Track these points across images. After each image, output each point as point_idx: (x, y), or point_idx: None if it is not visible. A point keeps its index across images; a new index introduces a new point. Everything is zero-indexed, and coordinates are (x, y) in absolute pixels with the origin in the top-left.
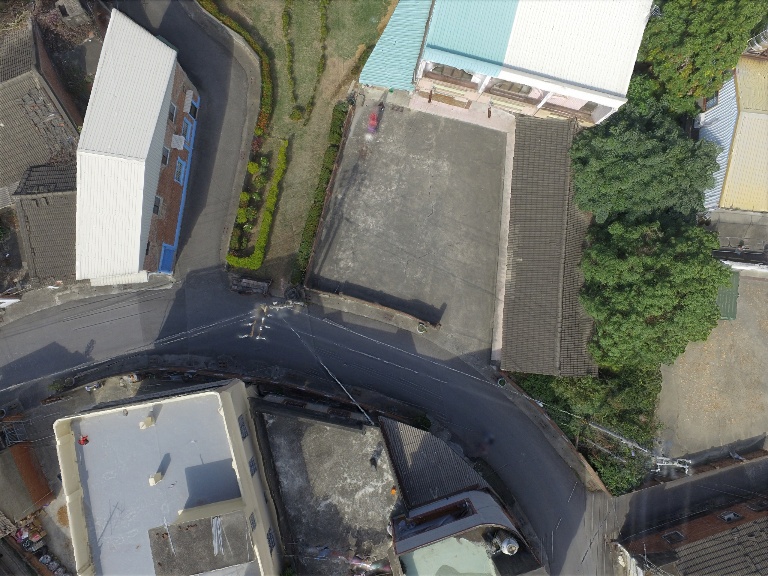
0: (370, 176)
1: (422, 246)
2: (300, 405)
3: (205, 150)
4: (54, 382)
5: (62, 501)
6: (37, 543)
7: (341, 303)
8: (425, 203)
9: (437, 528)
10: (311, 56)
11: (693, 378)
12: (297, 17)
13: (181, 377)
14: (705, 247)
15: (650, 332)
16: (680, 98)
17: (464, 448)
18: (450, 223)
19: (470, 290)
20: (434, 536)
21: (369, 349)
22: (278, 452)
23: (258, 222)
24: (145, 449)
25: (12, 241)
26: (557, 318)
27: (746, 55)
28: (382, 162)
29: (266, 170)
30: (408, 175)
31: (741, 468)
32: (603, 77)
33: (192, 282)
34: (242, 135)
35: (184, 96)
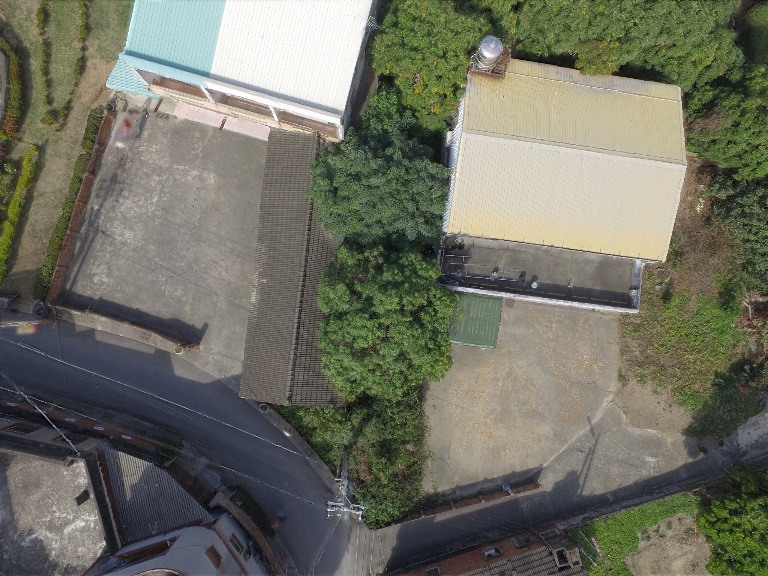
0: (129, 186)
1: (183, 262)
2: (32, 430)
3: None
4: None
5: None
6: None
7: (95, 321)
8: (188, 217)
9: (118, 571)
10: (70, 57)
11: (467, 407)
12: (56, 14)
13: None
14: (418, 276)
15: (356, 365)
16: (426, 115)
17: (222, 476)
18: (214, 238)
19: (234, 310)
20: None
21: (123, 370)
22: None
23: None
24: None
25: None
26: (291, 345)
27: (477, 72)
28: (143, 172)
29: (12, 177)
30: (171, 186)
31: (515, 501)
32: (319, 91)
33: None
34: None
35: None
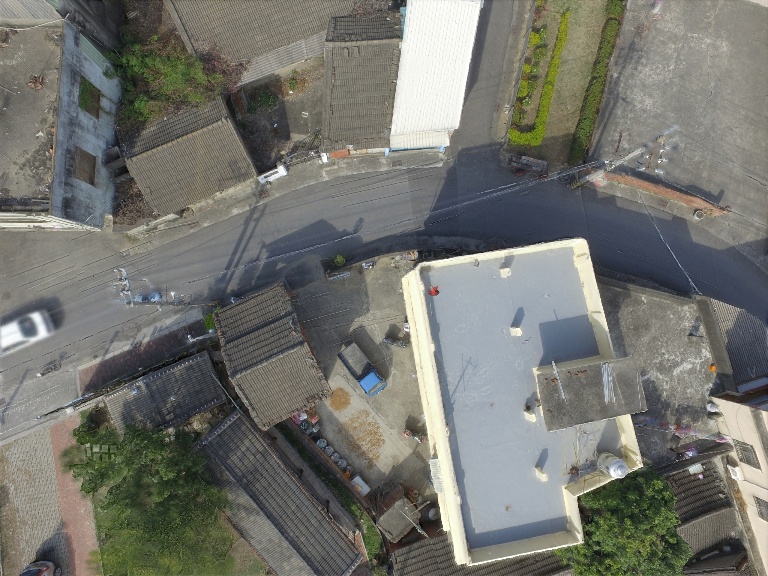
0: (647, 54)
1: (700, 129)
2: None
3: None
4: (321, 261)
5: (334, 384)
6: (315, 425)
7: (615, 187)
8: (704, 84)
9: None
10: None
11: None
12: None
13: None
14: None
15: None
16: None
17: None
18: (729, 106)
19: None
20: None
21: (644, 236)
22: None
23: (532, 99)
24: (498, 302)
25: (280, 110)
26: None
27: None
28: (659, 40)
29: None
30: (686, 54)
31: None
32: None
33: (464, 160)
34: (513, 8)
35: None
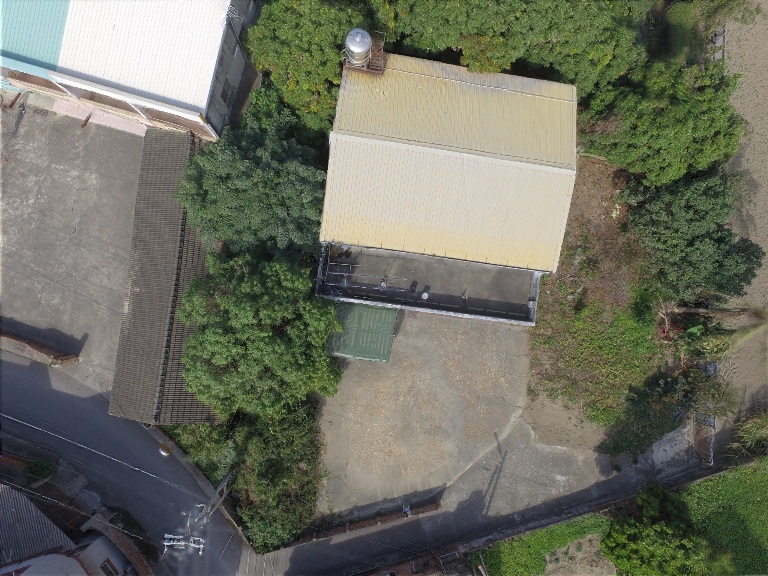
0: (4, 187)
1: (61, 268)
2: None
3: None
4: None
5: None
6: None
7: None
8: (67, 220)
9: None
10: None
11: (366, 423)
12: None
13: None
14: (282, 287)
15: (214, 383)
16: (306, 113)
17: (102, 497)
18: (96, 243)
19: (116, 319)
20: None
21: None
22: None
23: None
24: None
25: None
26: (160, 359)
27: (353, 68)
28: (19, 172)
29: None
30: (49, 187)
31: (417, 522)
32: (178, 87)
33: None
34: None
35: None
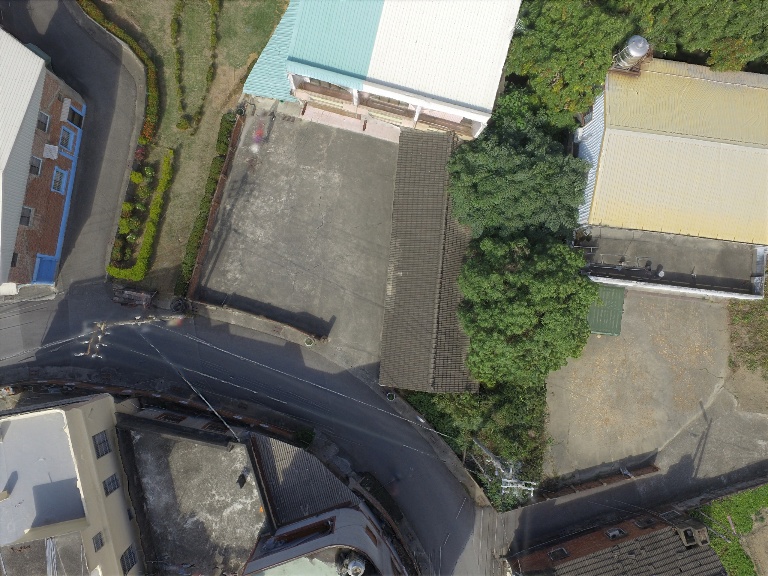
0: (259, 187)
1: (311, 258)
2: (179, 419)
3: (91, 159)
4: None
5: None
6: None
7: (229, 315)
8: (315, 215)
9: (291, 548)
10: (201, 64)
11: (584, 393)
12: (187, 24)
13: (60, 390)
14: (568, 265)
15: (511, 351)
16: (558, 112)
17: (352, 463)
18: (340, 235)
19: (360, 303)
20: (284, 557)
21: None
22: (144, 468)
23: (144, 233)
24: None
25: None
26: (432, 334)
27: (616, 70)
28: (272, 173)
29: (151, 180)
30: (298, 186)
31: (632, 484)
32: (469, 92)
33: (75, 293)
34: (130, 144)
35: (61, 105)
